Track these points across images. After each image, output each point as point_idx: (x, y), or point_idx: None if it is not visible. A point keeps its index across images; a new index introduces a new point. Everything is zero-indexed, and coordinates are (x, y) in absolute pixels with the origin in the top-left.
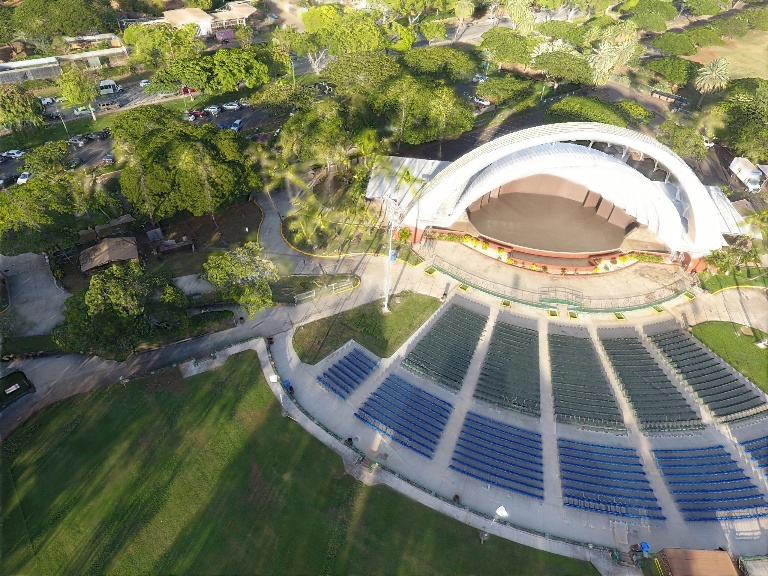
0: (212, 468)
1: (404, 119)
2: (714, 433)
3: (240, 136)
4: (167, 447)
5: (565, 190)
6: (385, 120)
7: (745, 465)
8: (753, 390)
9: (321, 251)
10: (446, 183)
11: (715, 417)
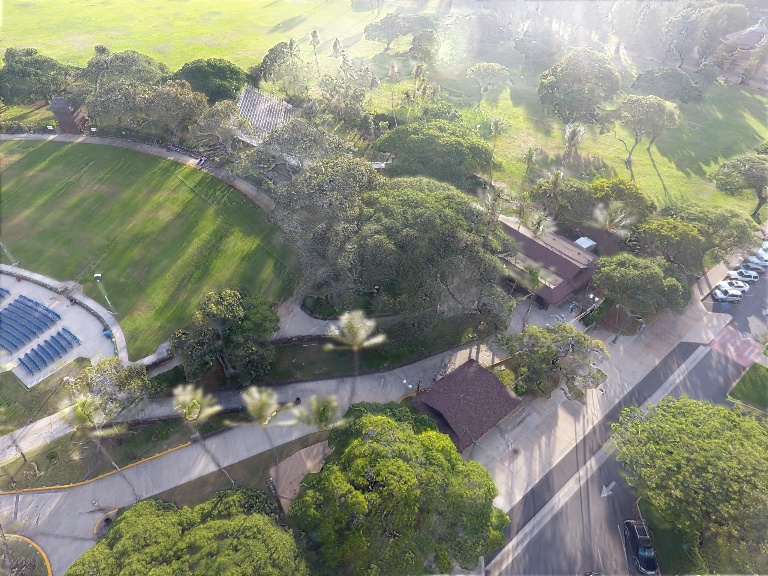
0: (169, 280)
1: None
2: None
3: None
4: (198, 287)
5: None
6: None
7: None
8: None
9: None
10: None
11: None
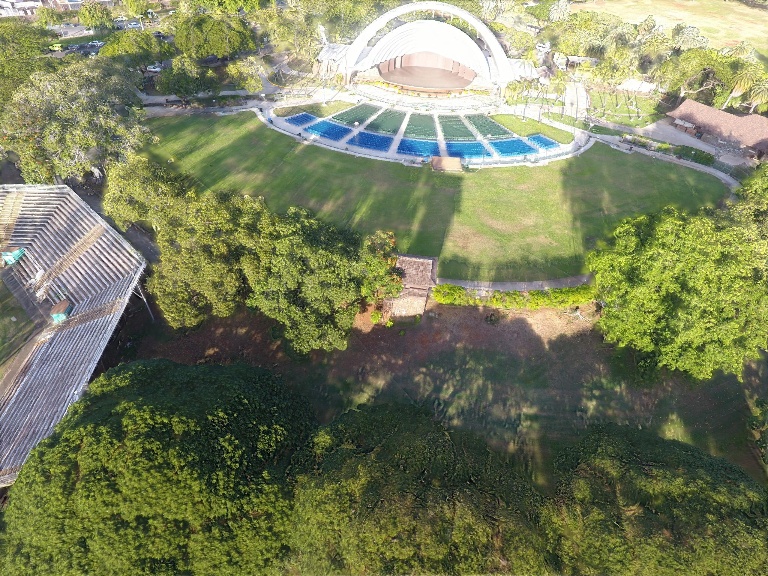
0: (234, 136)
1: (344, 22)
2: (480, 141)
3: None
4: (213, 130)
5: (441, 63)
6: (333, 24)
7: (488, 148)
8: (509, 132)
9: (290, 86)
10: (359, 40)
11: (483, 137)
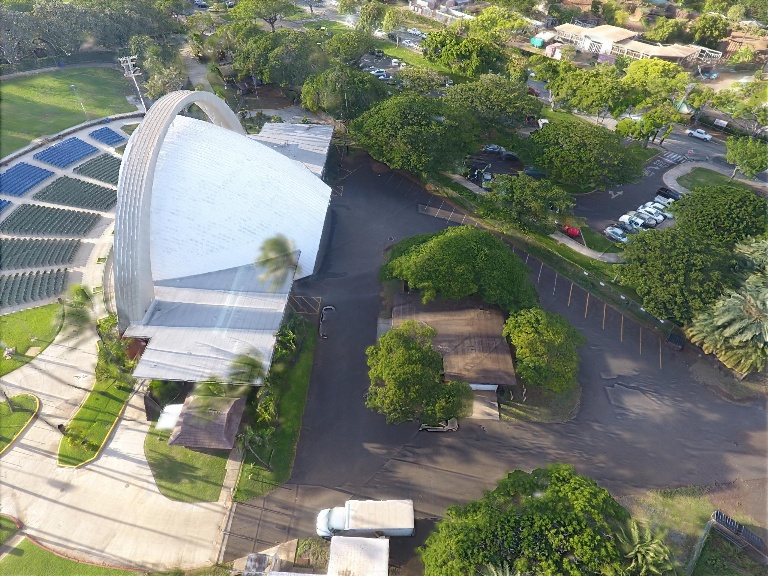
0: (68, 106)
1: None
2: None
3: (296, 52)
4: (85, 96)
5: None
6: None
7: None
8: None
9: None
10: None
11: None
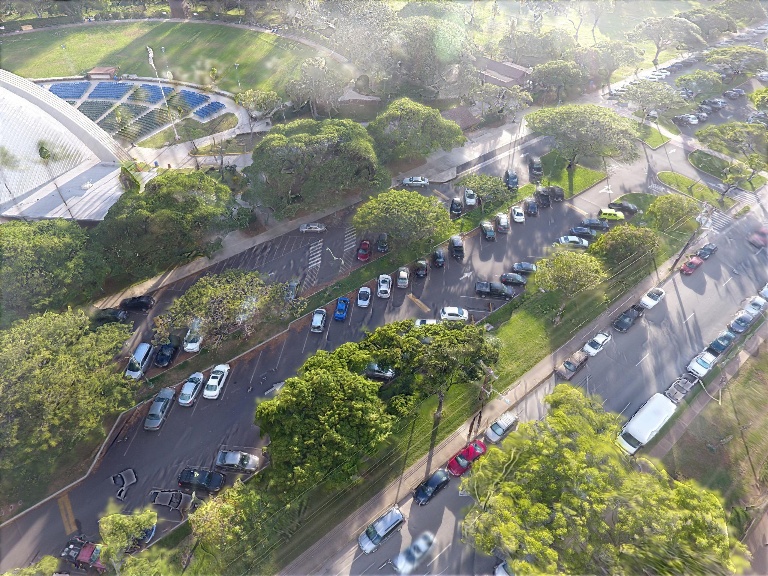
0: None
1: None
2: None
3: None
4: None
5: None
6: None
7: None
8: None
9: None
10: None
11: None
